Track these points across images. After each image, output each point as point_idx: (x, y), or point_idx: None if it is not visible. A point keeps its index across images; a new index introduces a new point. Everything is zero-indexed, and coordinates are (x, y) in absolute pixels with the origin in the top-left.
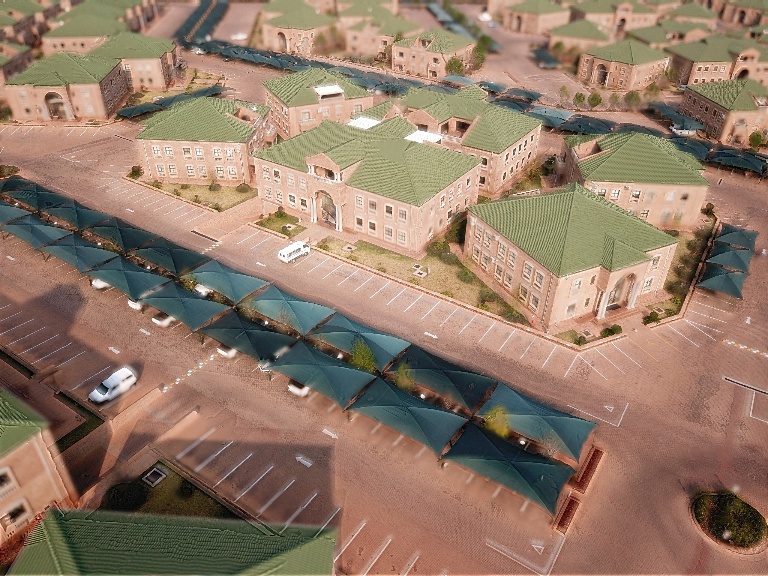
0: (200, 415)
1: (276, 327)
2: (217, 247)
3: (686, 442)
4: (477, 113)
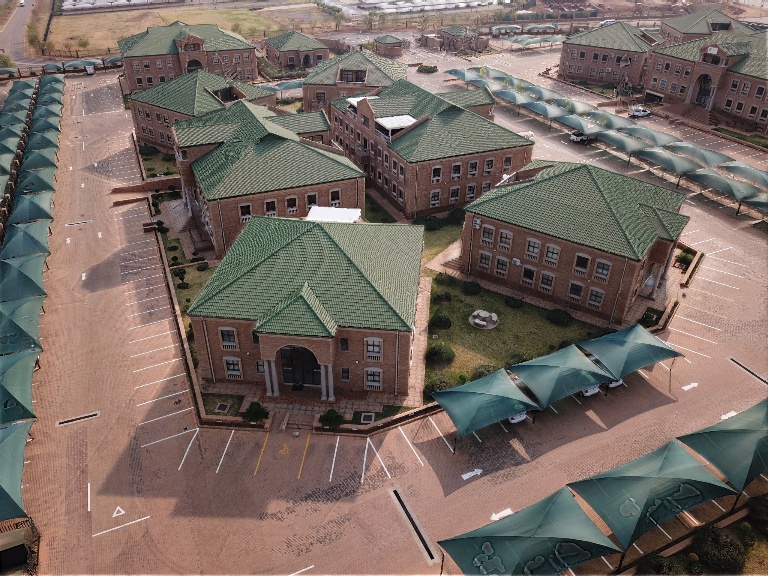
0: (596, 105)
1: (555, 99)
2: (579, 161)
3: (410, 78)
4: (262, 108)
